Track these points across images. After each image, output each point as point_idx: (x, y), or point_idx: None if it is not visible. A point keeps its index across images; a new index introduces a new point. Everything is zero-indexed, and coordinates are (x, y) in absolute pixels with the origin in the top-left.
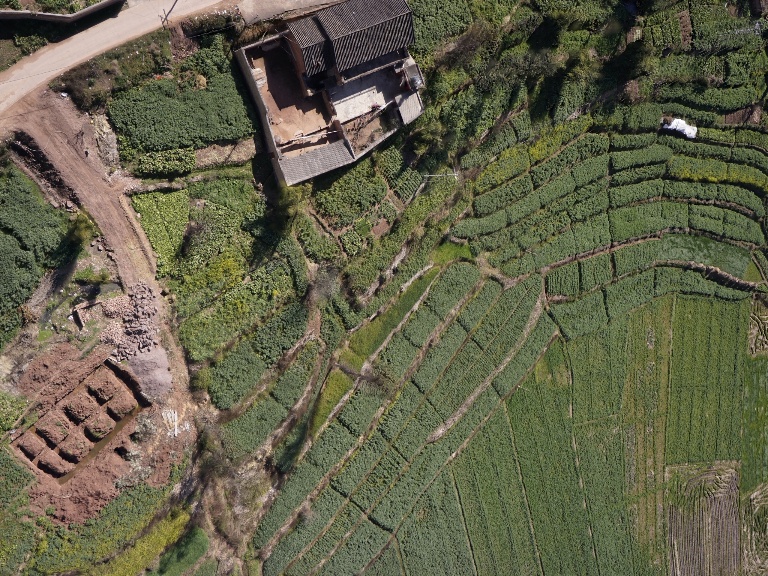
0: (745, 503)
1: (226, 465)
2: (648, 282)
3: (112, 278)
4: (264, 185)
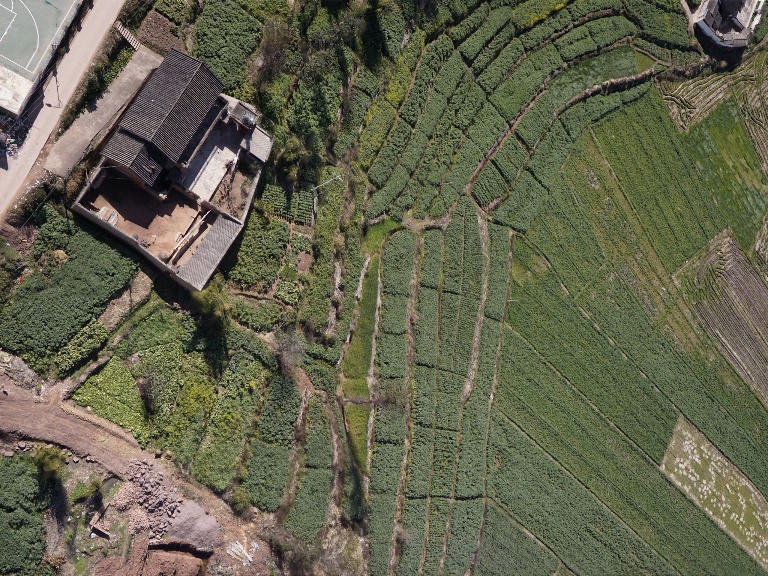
0: (754, 258)
1: (310, 551)
2: (560, 134)
3: (104, 477)
4: (179, 302)
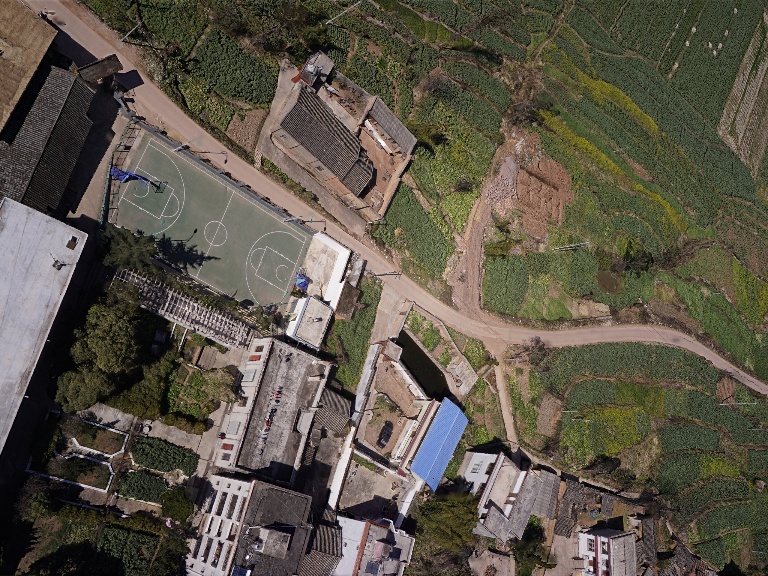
0: None
1: None
2: None
3: (492, 220)
4: None
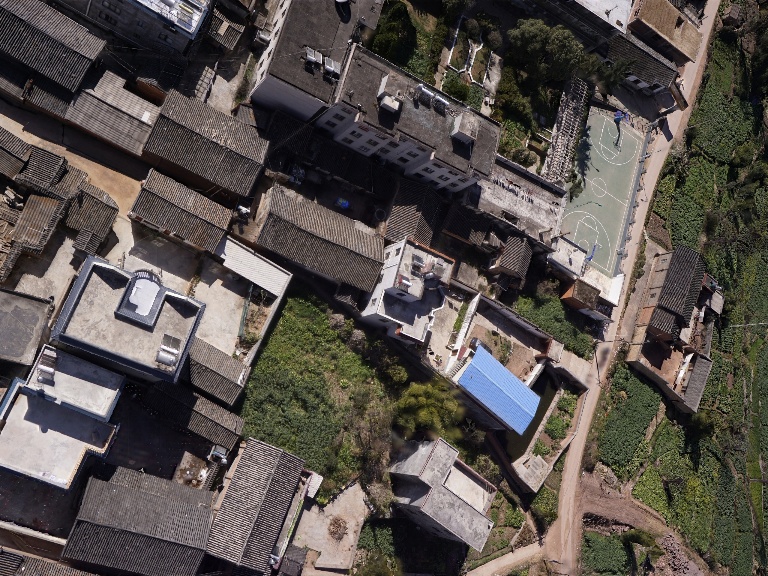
0: None
1: None
2: None
3: (652, 547)
4: (676, 419)
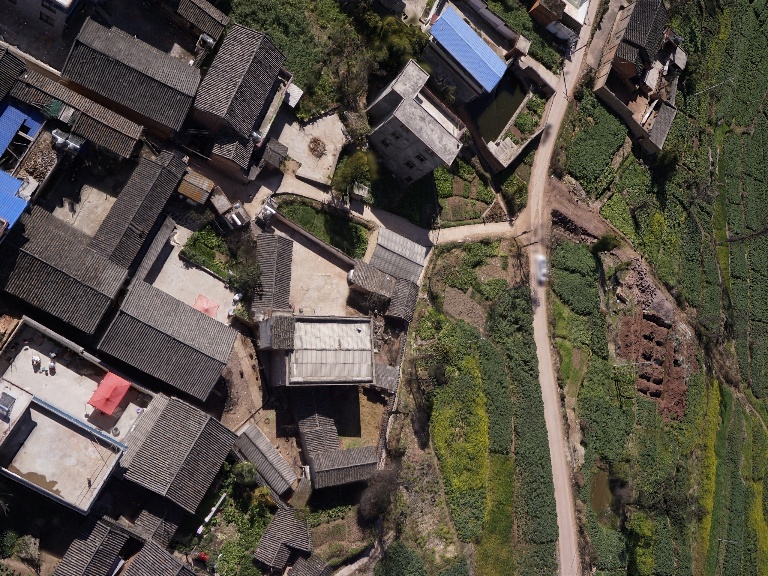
0: None
1: (714, 339)
2: None
3: None
4: (642, 159)
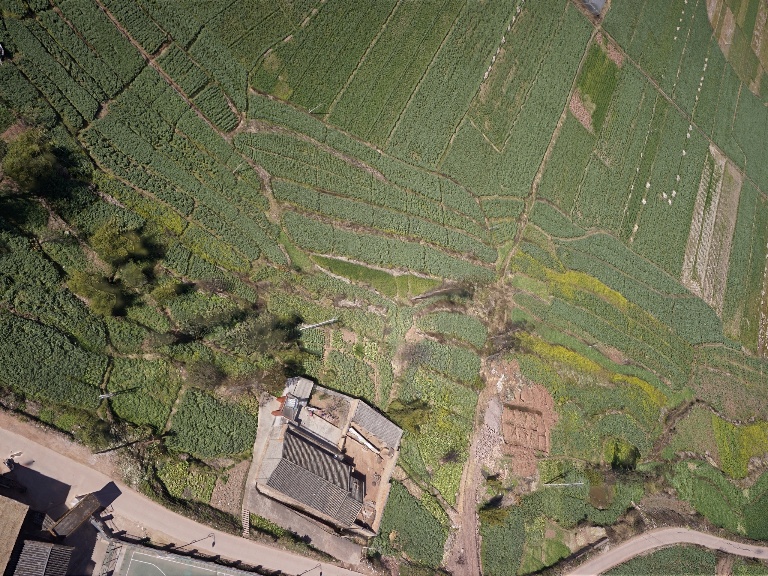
0: None
1: None
2: None
3: (483, 477)
4: None
